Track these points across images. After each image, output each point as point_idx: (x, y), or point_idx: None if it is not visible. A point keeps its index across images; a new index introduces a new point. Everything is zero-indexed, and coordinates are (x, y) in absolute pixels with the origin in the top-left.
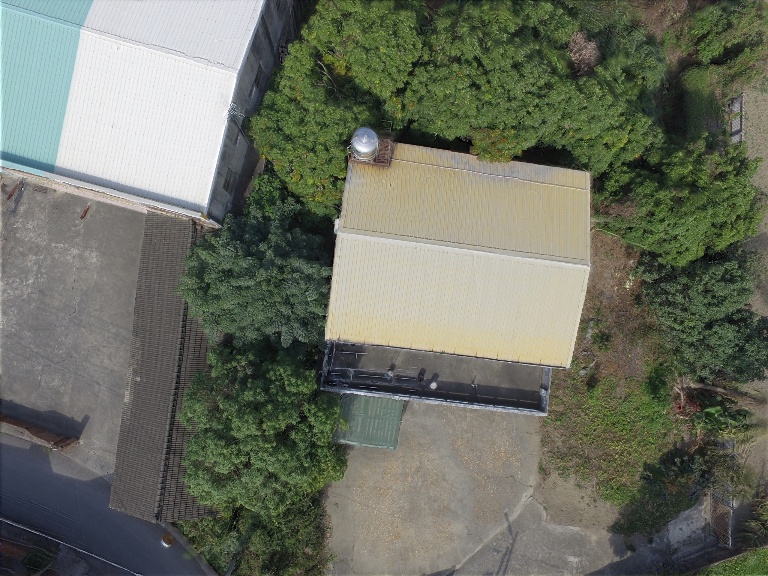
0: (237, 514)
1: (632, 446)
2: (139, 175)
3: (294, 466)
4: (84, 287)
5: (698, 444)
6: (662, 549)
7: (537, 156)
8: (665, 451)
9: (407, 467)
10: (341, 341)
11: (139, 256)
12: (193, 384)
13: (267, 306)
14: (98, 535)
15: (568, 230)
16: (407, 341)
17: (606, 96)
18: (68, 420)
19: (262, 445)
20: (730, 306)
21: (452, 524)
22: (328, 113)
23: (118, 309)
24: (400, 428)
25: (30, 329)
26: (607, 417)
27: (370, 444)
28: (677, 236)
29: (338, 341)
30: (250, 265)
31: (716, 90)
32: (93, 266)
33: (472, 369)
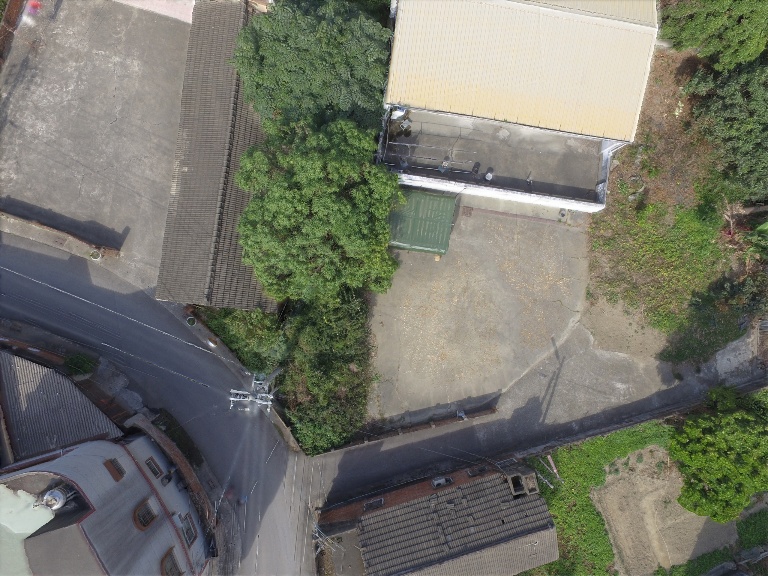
0: (284, 317)
1: (681, 273)
2: None
3: (353, 230)
4: (125, 96)
5: (747, 273)
6: (710, 379)
7: None
8: (714, 280)
9: (453, 287)
10: (401, 105)
11: (182, 66)
12: None
13: (326, 66)
14: (138, 349)
15: None
16: (469, 107)
17: None
18: (108, 231)
19: (325, 190)
20: None
21: (499, 347)
22: None
23: (160, 119)
24: None
25: (70, 136)
26: (656, 243)
27: (421, 246)
28: (741, 19)
29: (398, 105)
30: (309, 24)
31: None
32: (135, 75)
33: (527, 165)
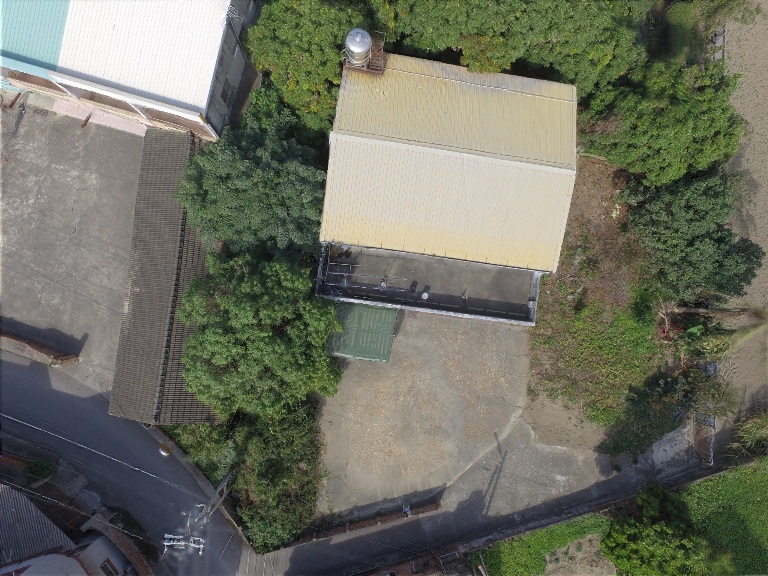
0: (233, 425)
1: (618, 369)
2: (139, 76)
3: (289, 362)
4: (84, 208)
5: (682, 368)
6: (646, 469)
7: (525, 70)
8: (650, 374)
9: (399, 387)
10: (335, 242)
11: (138, 179)
12: (191, 286)
13: (264, 207)
14: None
15: (555, 138)
16: (399, 243)
17: (591, 6)
18: (68, 338)
19: (258, 334)
20: (711, 222)
21: (443, 443)
22: (323, 12)
23: (117, 230)
24: (393, 349)
25: (30, 248)
26: (594, 341)
27: (363, 357)
28: (660, 150)
29: (332, 243)
30: (247, 168)
31: (700, 22)
32: (93, 188)
33: (462, 282)
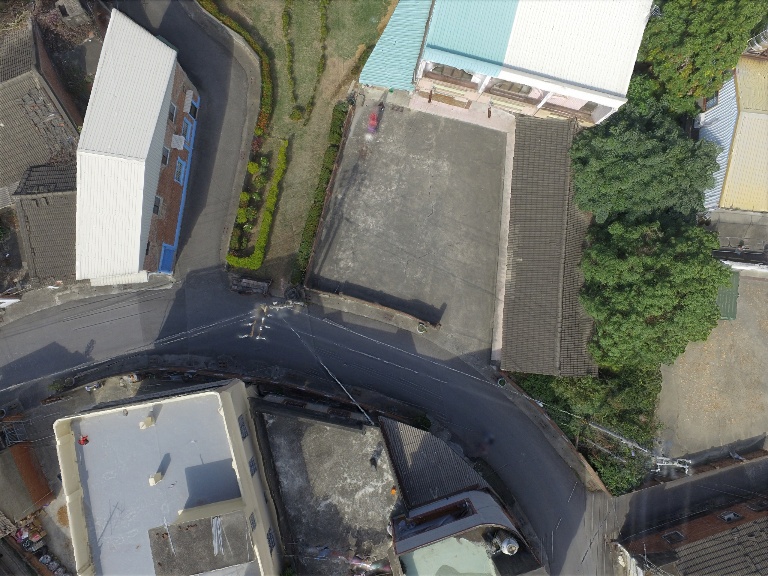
0: None
1: None
2: (571, 70)
3: None
4: (439, 192)
5: None
6: None
7: None
8: None
9: (721, 345)
10: (734, 208)
11: (483, 165)
12: (597, 252)
13: (672, 179)
14: (457, 407)
15: None
16: None
17: None
18: (429, 307)
19: (698, 287)
20: None
21: (762, 395)
22: (751, 7)
23: (467, 211)
24: None
25: (395, 229)
26: None
27: None
28: None
29: (731, 209)
30: (655, 146)
31: None
32: (445, 174)
33: None
